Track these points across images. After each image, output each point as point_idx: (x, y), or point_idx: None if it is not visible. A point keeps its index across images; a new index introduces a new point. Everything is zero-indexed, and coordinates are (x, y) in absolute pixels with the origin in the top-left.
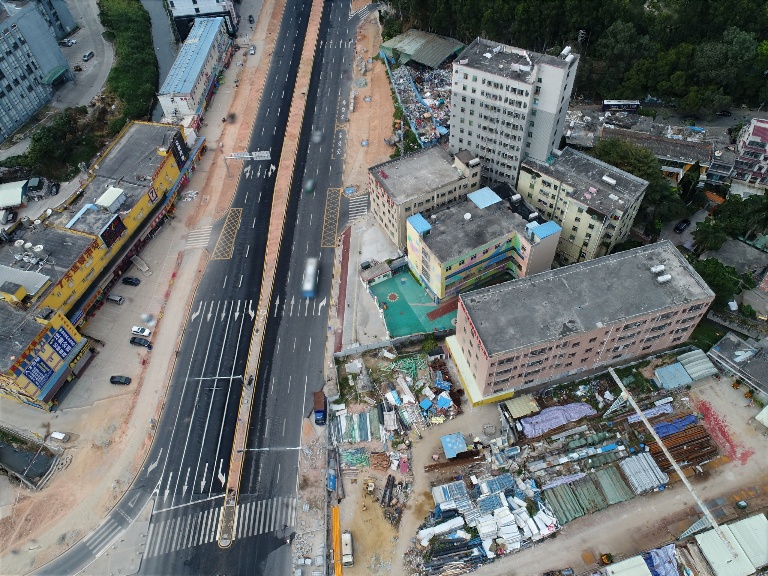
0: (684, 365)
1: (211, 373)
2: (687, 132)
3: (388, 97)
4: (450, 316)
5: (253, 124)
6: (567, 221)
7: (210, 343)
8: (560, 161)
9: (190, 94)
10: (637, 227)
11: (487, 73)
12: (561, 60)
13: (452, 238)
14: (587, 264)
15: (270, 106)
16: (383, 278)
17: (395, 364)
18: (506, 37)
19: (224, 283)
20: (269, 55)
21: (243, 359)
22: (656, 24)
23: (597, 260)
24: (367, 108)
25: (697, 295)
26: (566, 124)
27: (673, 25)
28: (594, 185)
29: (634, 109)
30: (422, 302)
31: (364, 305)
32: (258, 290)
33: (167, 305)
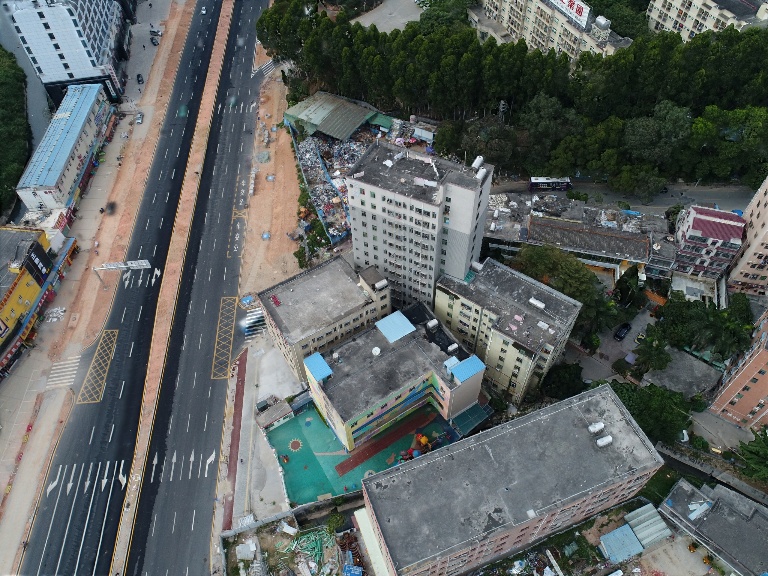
0: (633, 527)
1: (67, 572)
2: (622, 217)
3: (293, 176)
4: (363, 468)
5: (136, 215)
6: (492, 350)
7: (68, 527)
8: (481, 277)
9: (55, 187)
10: (573, 337)
11: (386, 191)
12: (471, 178)
13: (358, 382)
14: (515, 423)
15: (157, 190)
16: (284, 420)
17: (296, 543)
18: (423, 102)
19: (90, 437)
20: (159, 124)
21: (109, 548)
22: (582, 95)
23: (526, 417)
24: (270, 189)
25: (643, 461)
26: (490, 213)
27: (601, 95)
28: (520, 309)
29: (564, 187)
30: (330, 450)
31: (261, 458)
32: (132, 445)
33: (17, 474)
